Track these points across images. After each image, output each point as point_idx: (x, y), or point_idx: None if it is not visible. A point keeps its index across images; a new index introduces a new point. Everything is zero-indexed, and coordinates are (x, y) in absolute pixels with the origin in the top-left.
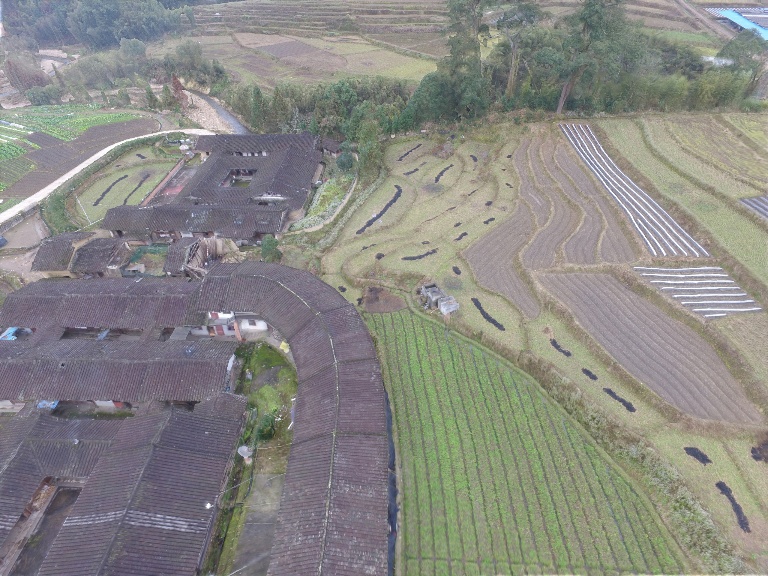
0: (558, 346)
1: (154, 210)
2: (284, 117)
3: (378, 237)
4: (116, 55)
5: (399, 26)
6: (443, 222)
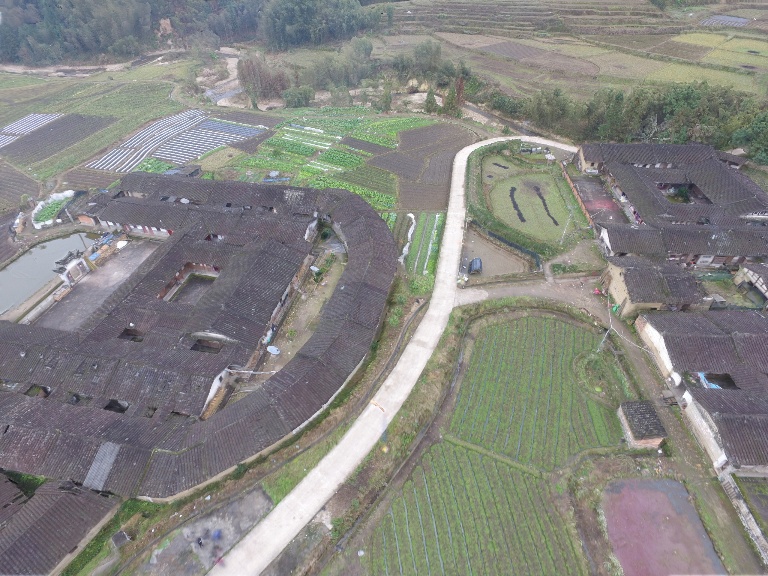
0: None
1: (664, 231)
2: (639, 125)
3: None
4: (349, 55)
5: (612, 27)
6: None
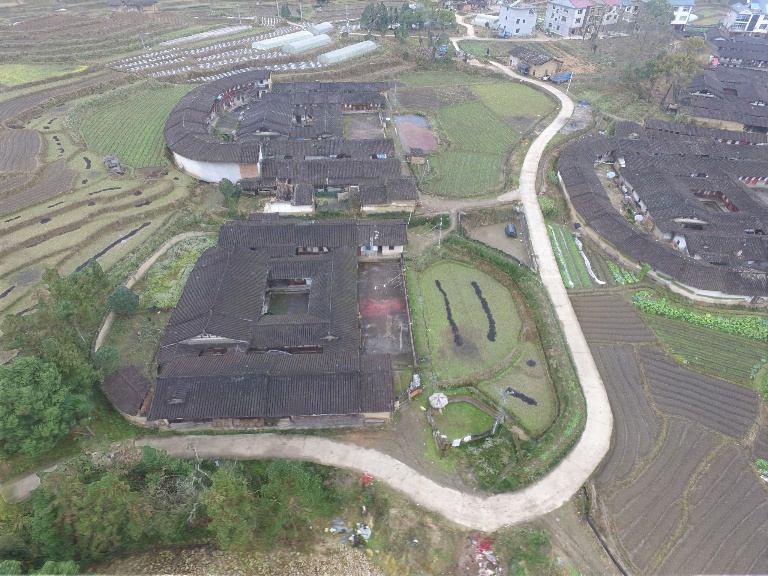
0: (62, 151)
1: None
2: None
3: (132, 213)
4: None
5: None
6: (59, 223)
